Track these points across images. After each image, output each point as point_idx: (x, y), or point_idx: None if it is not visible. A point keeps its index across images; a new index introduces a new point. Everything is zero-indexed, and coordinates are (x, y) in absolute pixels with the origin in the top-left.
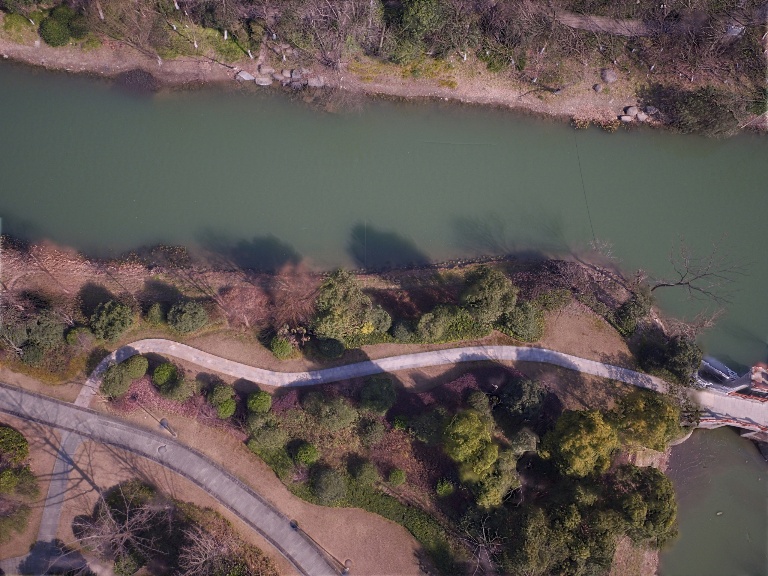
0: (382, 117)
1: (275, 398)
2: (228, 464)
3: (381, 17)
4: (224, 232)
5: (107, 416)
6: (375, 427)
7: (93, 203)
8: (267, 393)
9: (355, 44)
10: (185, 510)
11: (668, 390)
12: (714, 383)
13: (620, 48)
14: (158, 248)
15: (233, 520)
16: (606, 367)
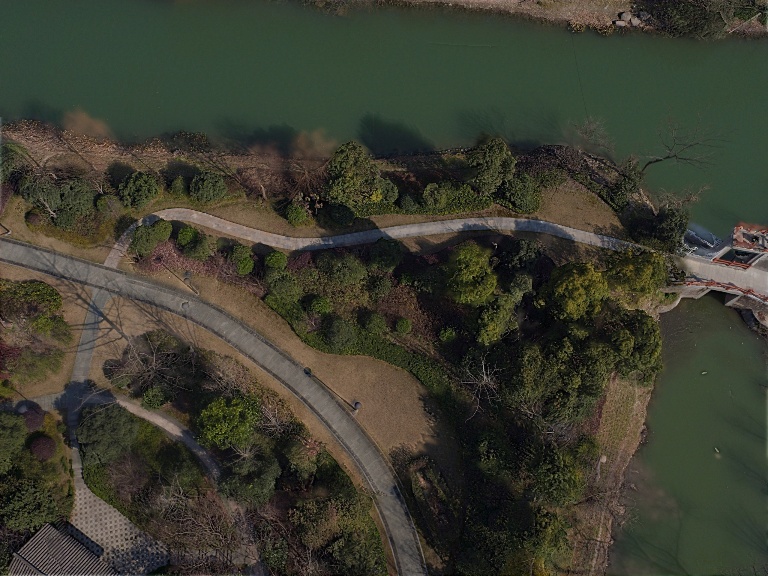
0: (390, 20)
1: (290, 258)
2: (246, 319)
3: None
4: (241, 122)
5: (134, 276)
6: (383, 282)
7: (119, 94)
8: (283, 253)
9: None
10: (207, 356)
11: None
12: (700, 252)
13: None
14: (180, 134)
15: (251, 367)
16: (599, 237)
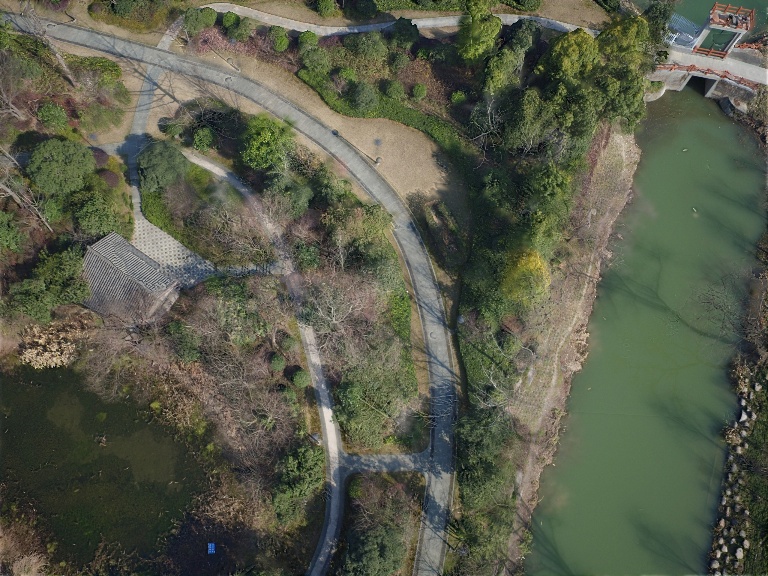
0: None
1: None
2: (282, 91)
3: None
4: None
5: (183, 56)
6: (402, 55)
7: None
8: None
9: None
10: (248, 117)
11: (644, 48)
12: (682, 44)
13: None
14: None
15: (286, 128)
16: (593, 31)
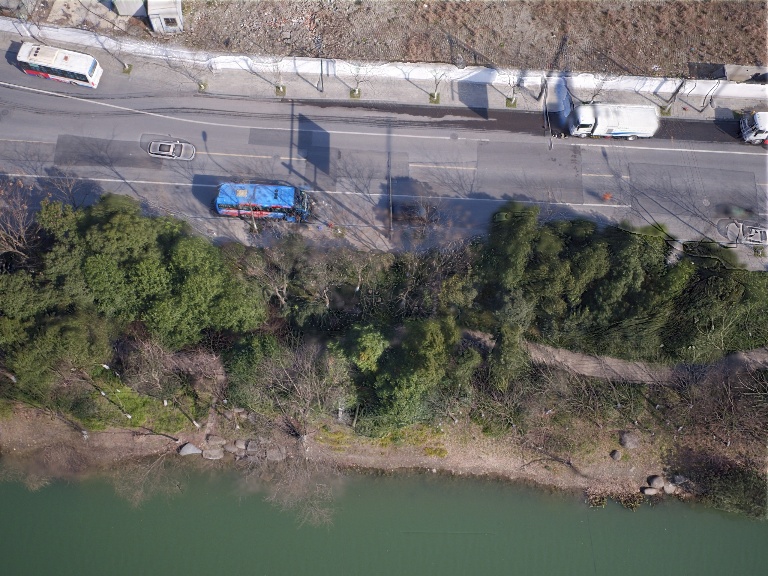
0: (357, 501)
1: None
2: None
3: (353, 402)
4: None
5: None
6: None
7: None
8: None
9: None
10: None
11: None
12: None
13: (641, 403)
14: None
15: None
16: None
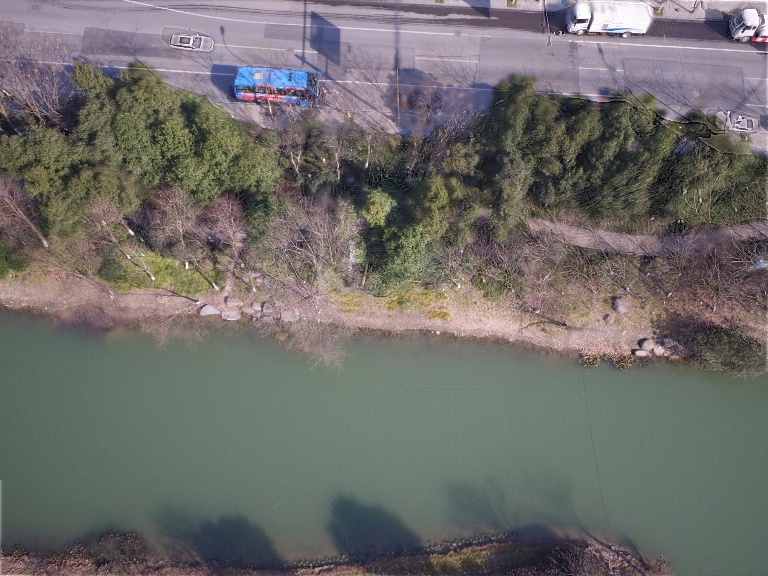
0: (365, 358)
1: None
2: None
3: (363, 258)
4: (184, 509)
5: None
6: None
7: (33, 478)
8: None
9: (334, 275)
10: None
11: None
12: None
13: (633, 272)
14: (107, 536)
15: None
16: None
